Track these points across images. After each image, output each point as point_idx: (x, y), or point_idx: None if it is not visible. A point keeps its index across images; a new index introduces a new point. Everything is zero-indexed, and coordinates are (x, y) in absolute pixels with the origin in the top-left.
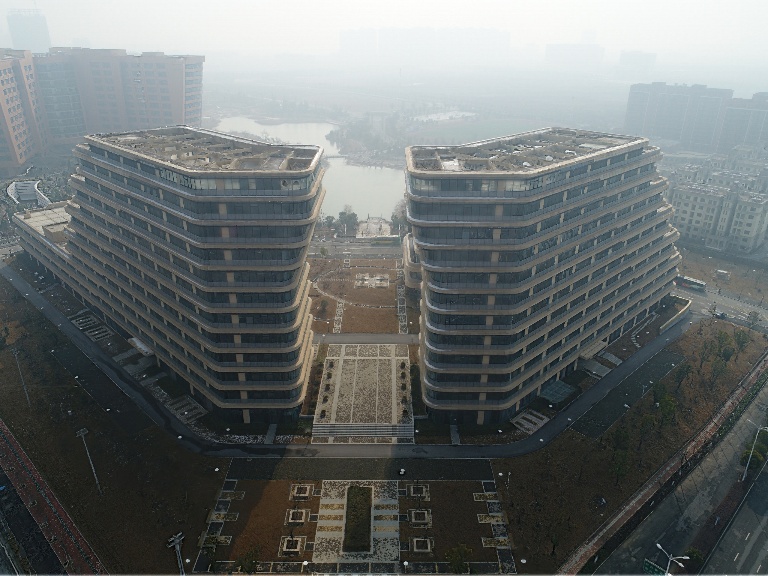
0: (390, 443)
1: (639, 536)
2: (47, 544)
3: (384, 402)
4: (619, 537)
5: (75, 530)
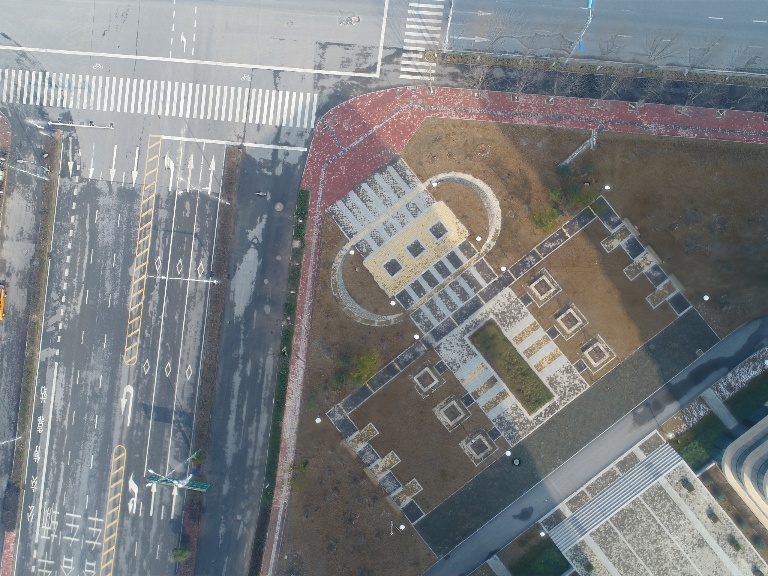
0: (567, 501)
1: (244, 555)
2: (767, 110)
3: (634, 571)
4: (259, 536)
5: (763, 140)
